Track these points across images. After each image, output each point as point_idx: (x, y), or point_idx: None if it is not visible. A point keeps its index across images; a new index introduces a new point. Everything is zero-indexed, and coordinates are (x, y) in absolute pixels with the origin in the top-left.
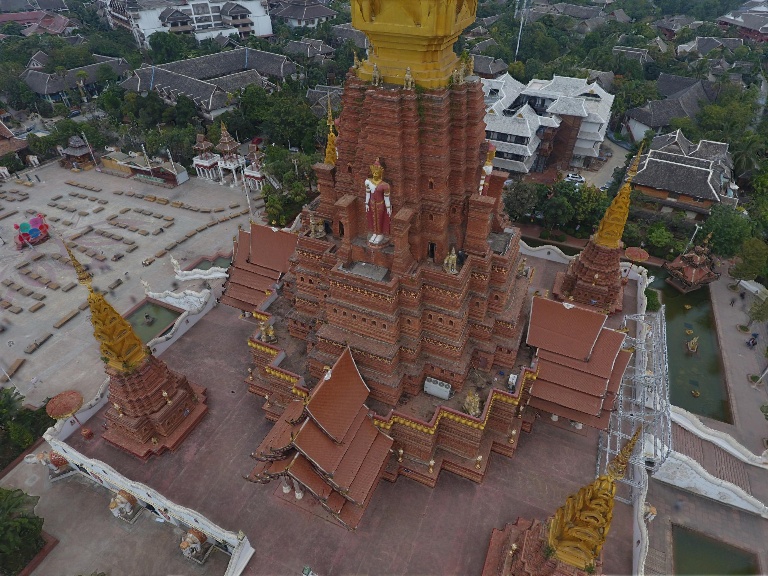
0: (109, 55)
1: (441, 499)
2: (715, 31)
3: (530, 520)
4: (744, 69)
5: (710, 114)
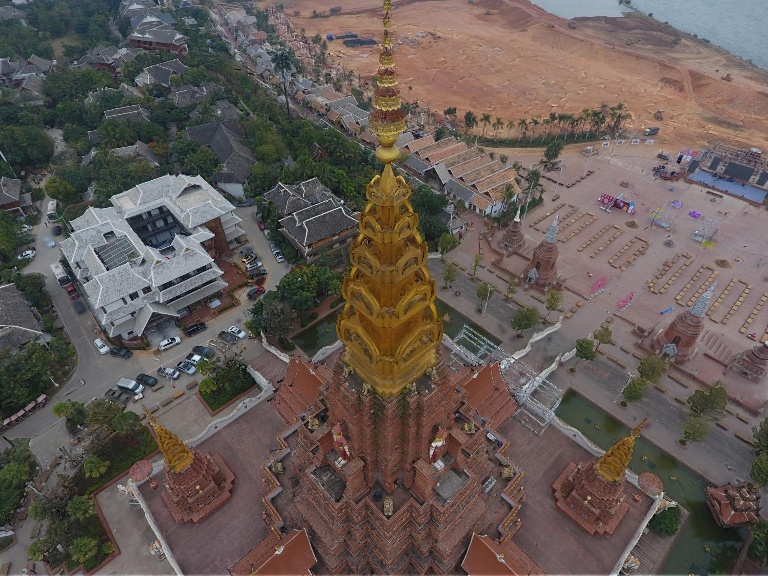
0: None
1: (528, 527)
2: (151, 58)
3: (550, 481)
4: (218, 92)
5: (268, 153)
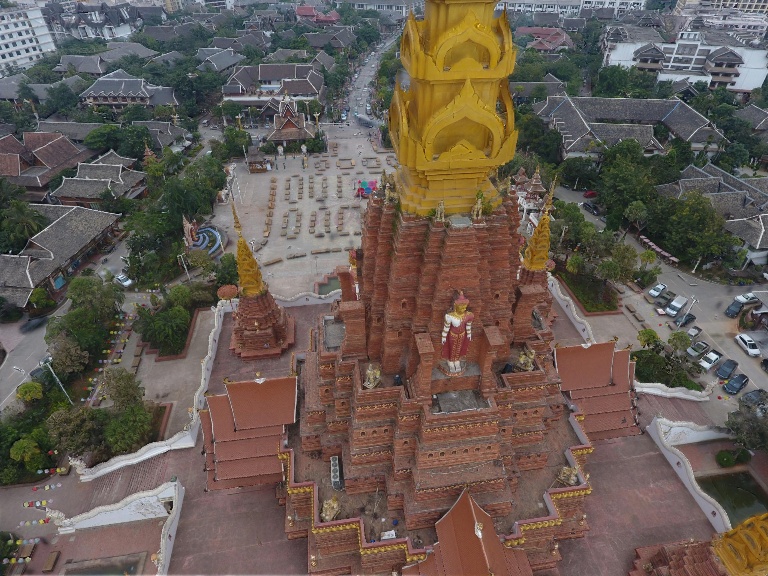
0: (563, 77)
1: (281, 551)
2: None
3: None
4: None
5: None
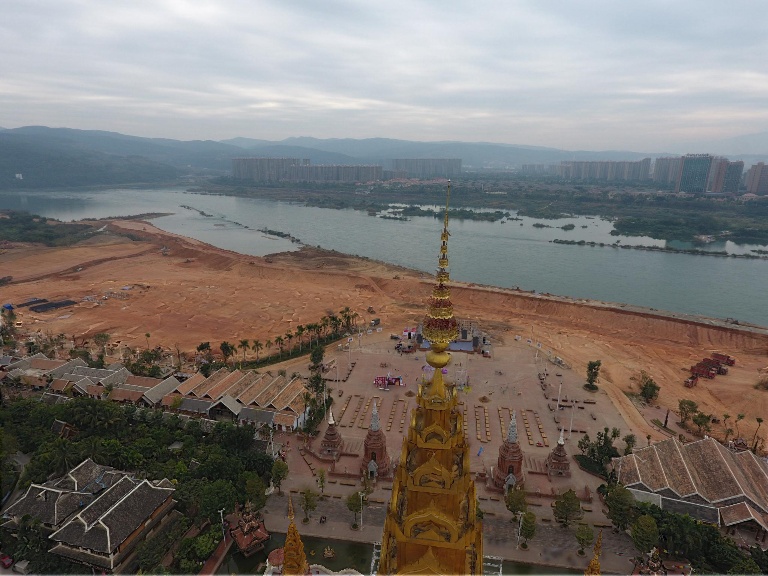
0: None
1: None
2: None
3: None
4: None
5: None
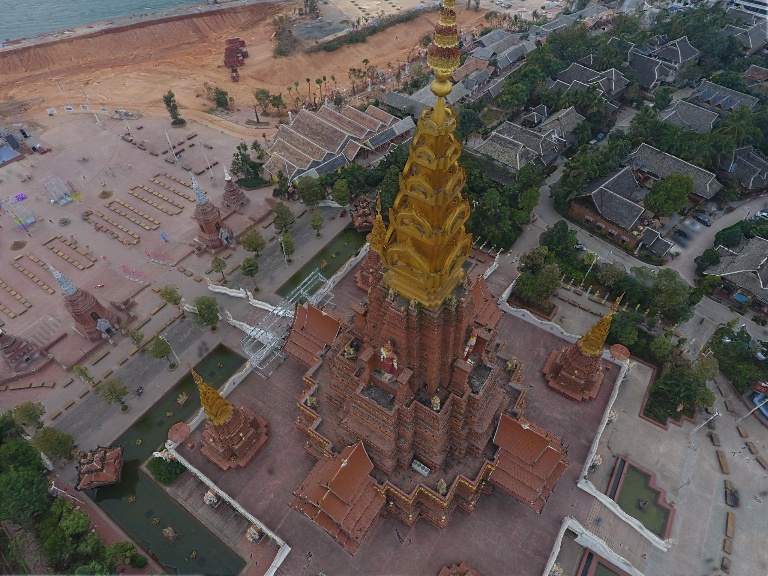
0: None
1: None
2: None
3: None
4: None
5: None
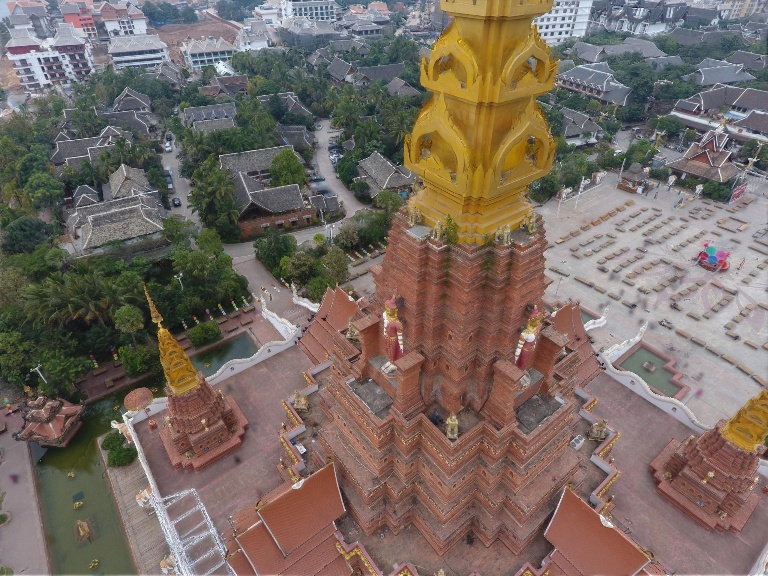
0: None
1: None
2: None
3: (237, 455)
4: None
5: None
